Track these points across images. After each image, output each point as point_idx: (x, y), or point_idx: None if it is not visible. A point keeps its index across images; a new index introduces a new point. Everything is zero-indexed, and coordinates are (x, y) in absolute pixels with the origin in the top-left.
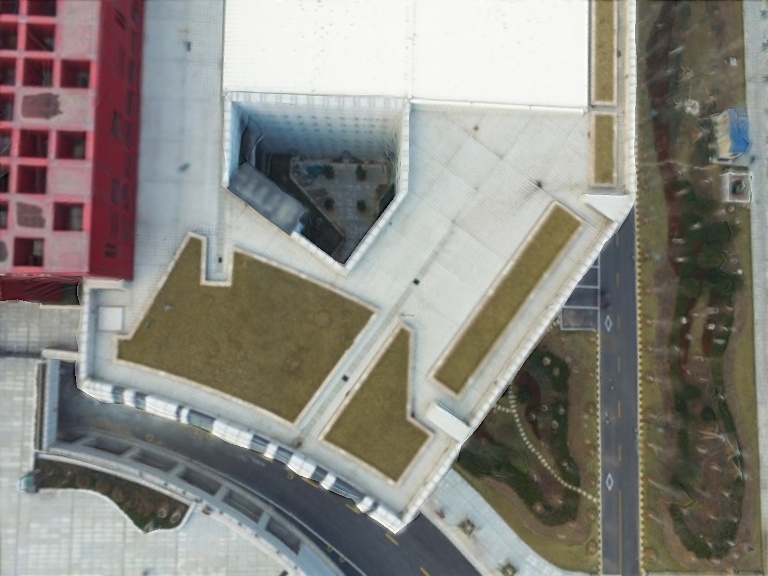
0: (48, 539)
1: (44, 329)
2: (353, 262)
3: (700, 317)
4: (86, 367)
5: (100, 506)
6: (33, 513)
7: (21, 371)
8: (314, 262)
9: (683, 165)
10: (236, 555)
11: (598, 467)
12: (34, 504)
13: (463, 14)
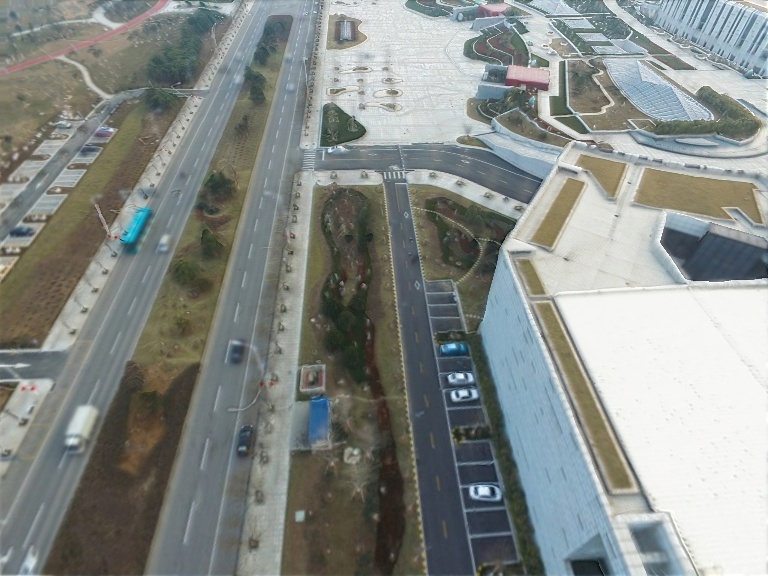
0: None
1: None
2: None
3: None
4: (764, 177)
5: None
6: None
7: None
8: None
9: (360, 398)
10: None
11: (415, 220)
12: None
13: (688, 346)
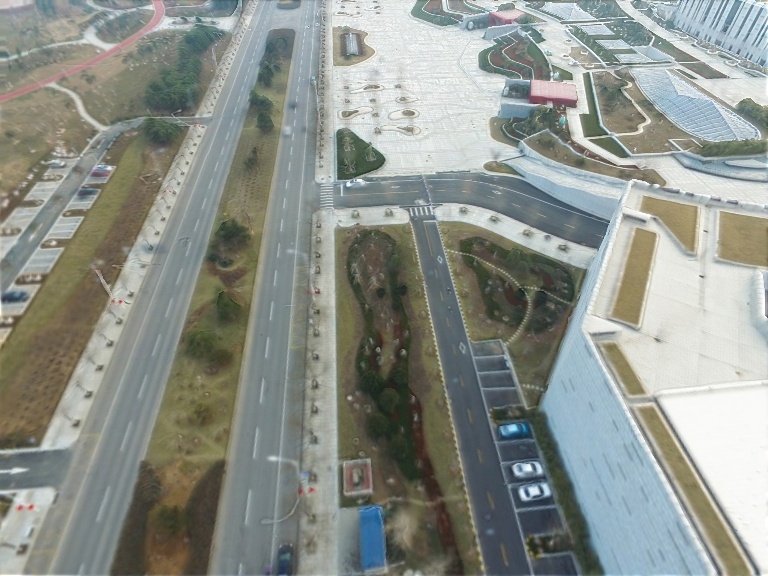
0: None
1: None
2: (758, 275)
3: (387, 357)
4: None
5: None
6: None
7: None
8: None
9: (414, 501)
10: None
11: (450, 265)
12: None
13: None
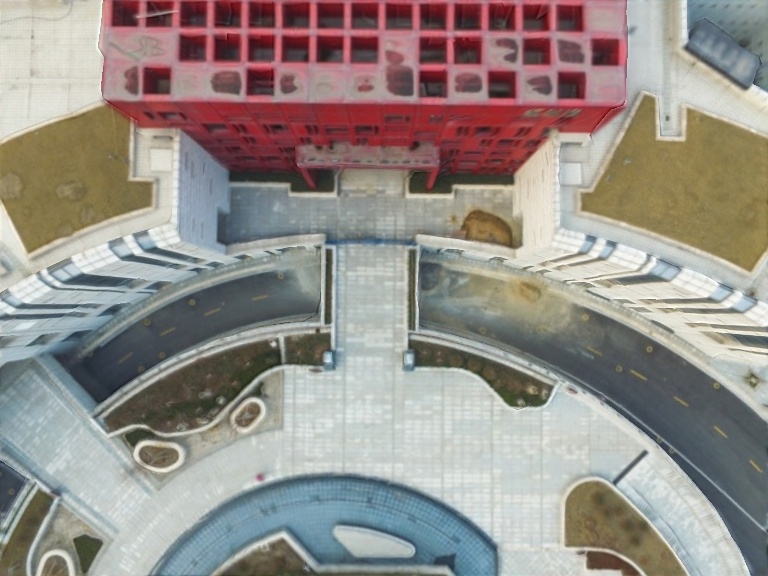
0: (421, 415)
1: (410, 218)
2: None
3: None
4: None
5: (468, 385)
6: (407, 391)
7: (390, 257)
8: (762, 118)
9: None
10: (597, 434)
11: None
12: (407, 382)
13: None
